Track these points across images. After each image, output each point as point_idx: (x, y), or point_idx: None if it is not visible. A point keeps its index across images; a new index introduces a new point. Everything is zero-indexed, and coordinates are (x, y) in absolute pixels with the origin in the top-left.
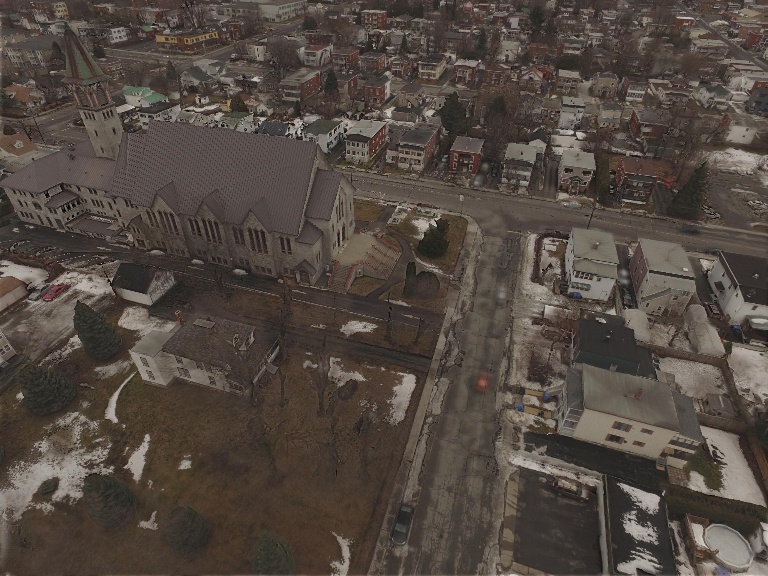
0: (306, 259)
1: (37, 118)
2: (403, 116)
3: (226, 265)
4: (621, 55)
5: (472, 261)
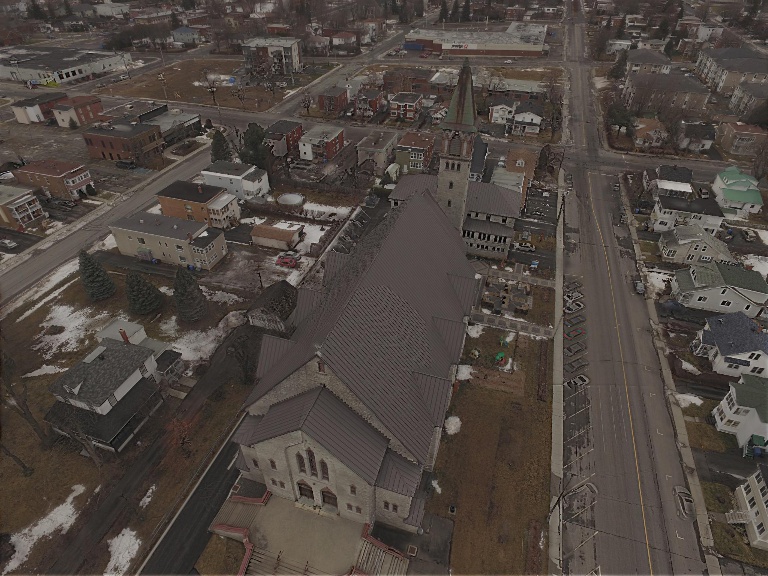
0: None
1: (621, 155)
2: None
3: None
4: None
5: None
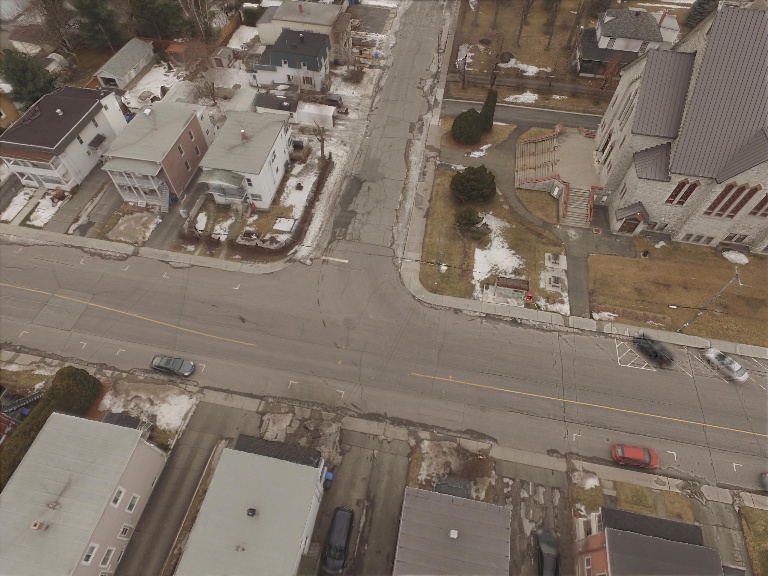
0: None
1: None
2: None
3: None
4: None
5: (412, 189)
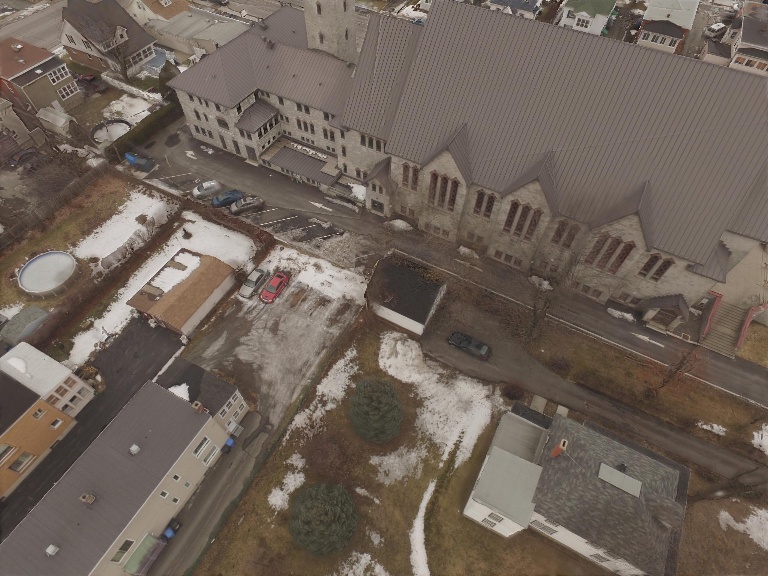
0: (683, 294)
1: None
2: None
3: (516, 266)
4: None
5: None
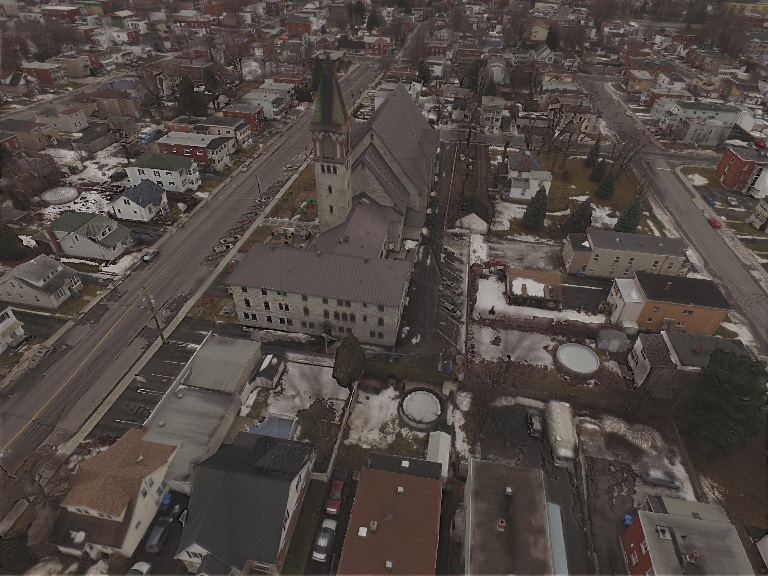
0: None
1: None
2: (102, 142)
3: None
4: (10, 41)
5: None
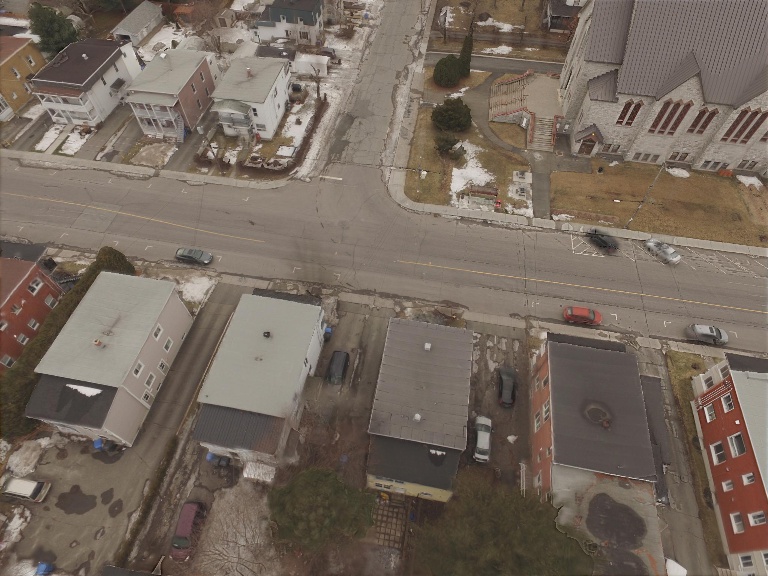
0: None
1: None
2: None
3: None
4: None
5: (398, 123)
